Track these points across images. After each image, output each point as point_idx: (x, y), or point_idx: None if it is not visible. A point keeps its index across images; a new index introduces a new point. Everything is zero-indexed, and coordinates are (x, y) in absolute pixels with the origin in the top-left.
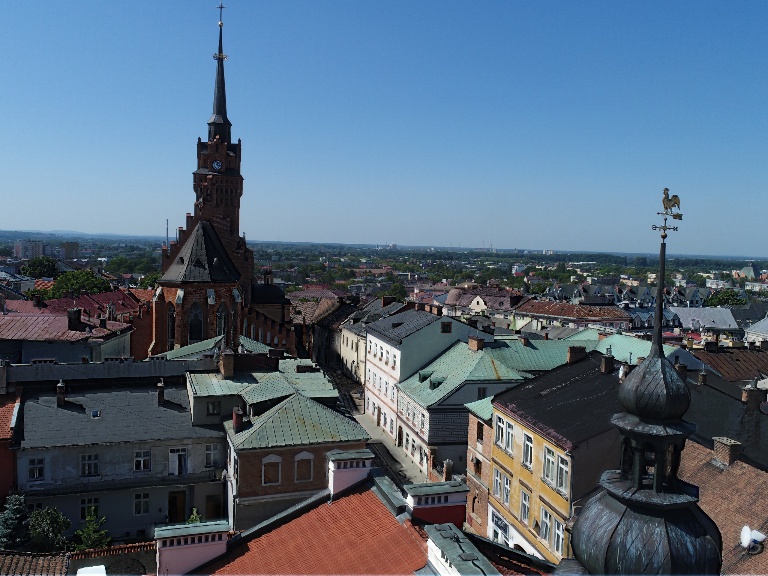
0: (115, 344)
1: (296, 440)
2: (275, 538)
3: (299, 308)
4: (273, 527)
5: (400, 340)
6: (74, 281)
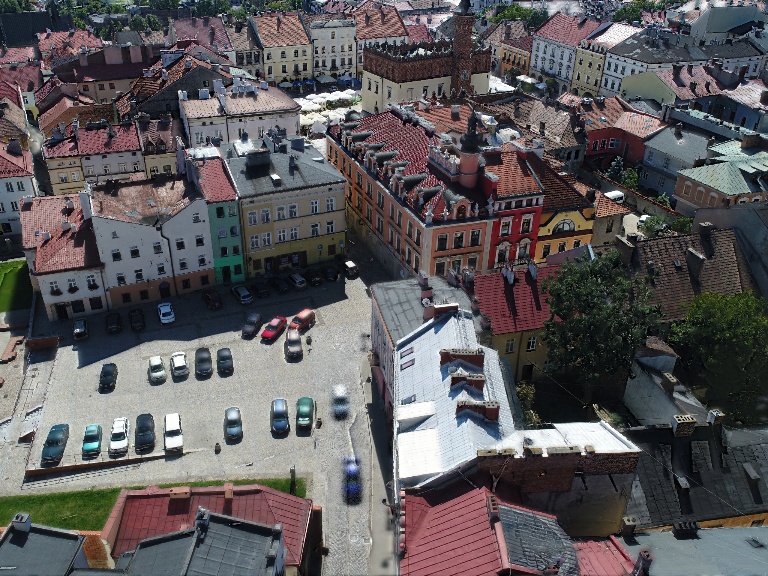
0: None
1: (700, 180)
2: None
3: None
4: None
5: None
6: None
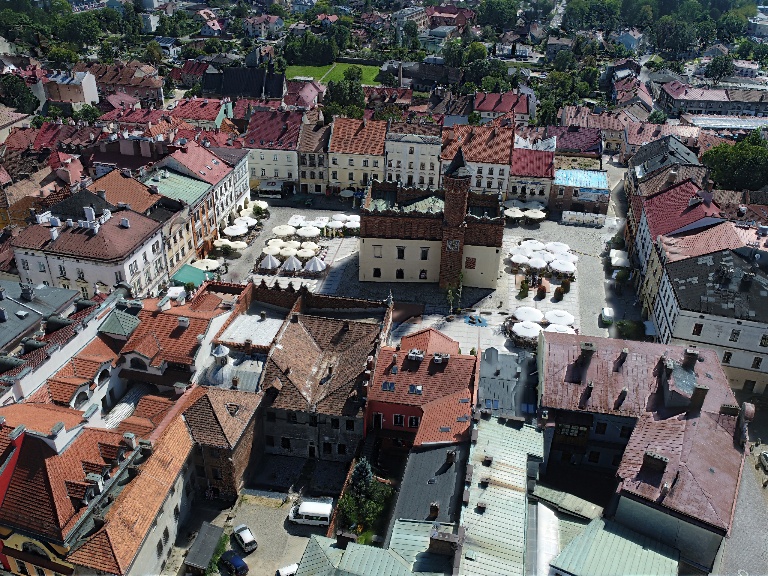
0: (667, 517)
1: (300, 570)
2: None
3: None
4: None
5: None
6: None
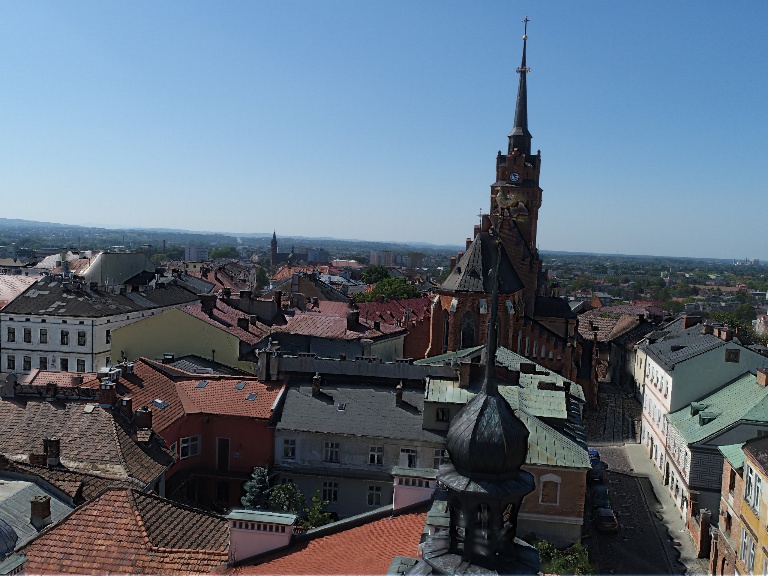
0: (387, 346)
1: None
2: (330, 541)
3: (596, 324)
4: (335, 530)
5: (672, 365)
6: (388, 287)
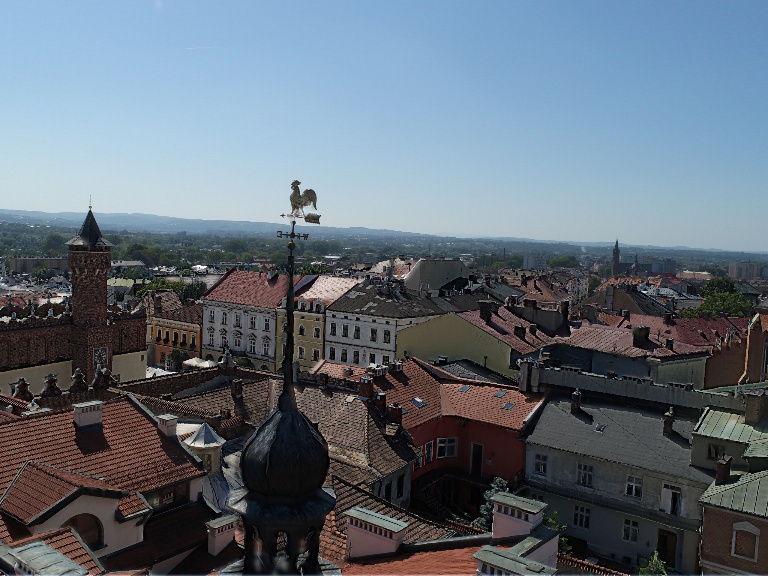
0: (681, 367)
1: None
2: (428, 557)
3: None
4: (439, 548)
5: None
6: (720, 302)
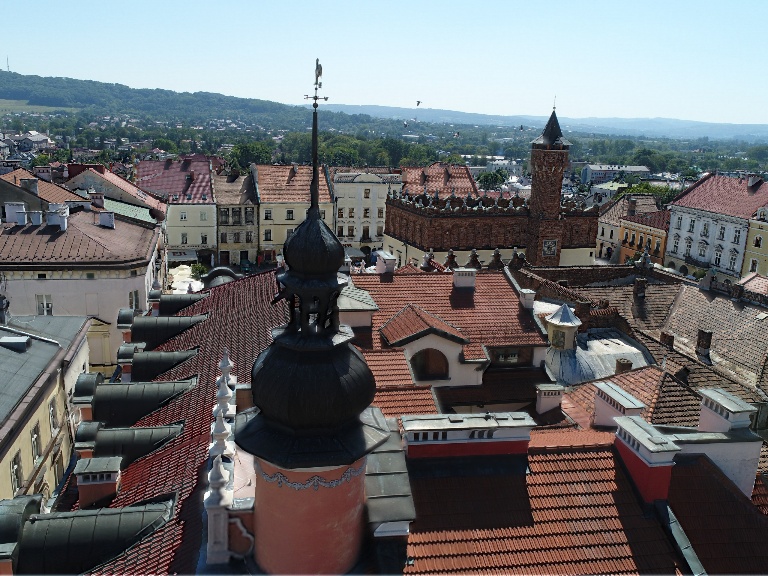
0: None
1: None
2: None
3: None
4: (660, 431)
5: None
6: None
